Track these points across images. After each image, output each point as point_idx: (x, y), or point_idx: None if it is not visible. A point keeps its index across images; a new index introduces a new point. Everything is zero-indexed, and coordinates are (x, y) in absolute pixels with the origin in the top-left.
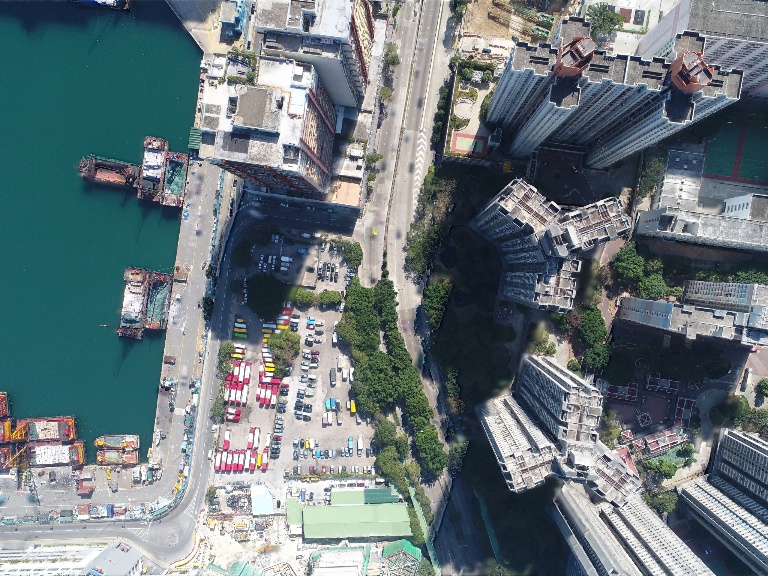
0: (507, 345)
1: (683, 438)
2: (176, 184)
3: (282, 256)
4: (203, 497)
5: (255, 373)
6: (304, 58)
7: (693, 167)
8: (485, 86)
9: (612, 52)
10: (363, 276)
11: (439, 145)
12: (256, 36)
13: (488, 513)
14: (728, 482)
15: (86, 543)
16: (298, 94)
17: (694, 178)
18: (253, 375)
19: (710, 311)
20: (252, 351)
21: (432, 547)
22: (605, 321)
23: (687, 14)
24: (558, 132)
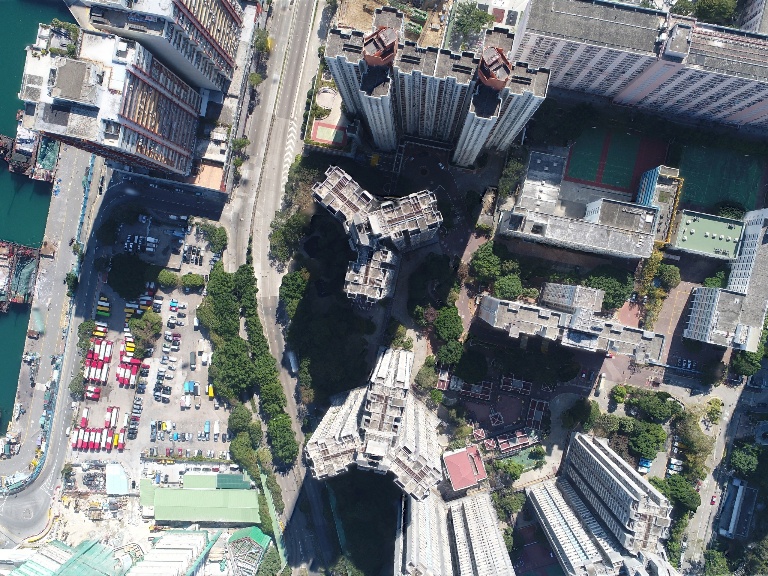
0: (367, 338)
1: (534, 440)
2: (48, 159)
3: (148, 237)
4: (60, 474)
5: (117, 352)
6: (133, 35)
7: (554, 169)
8: None
9: None
10: (228, 261)
11: None
12: None
13: (336, 504)
14: (572, 485)
15: None
16: (119, 70)
17: (554, 180)
18: (115, 354)
19: (536, 311)
20: (115, 330)
21: (280, 535)
22: (464, 319)
23: (528, 14)
24: (418, 127)
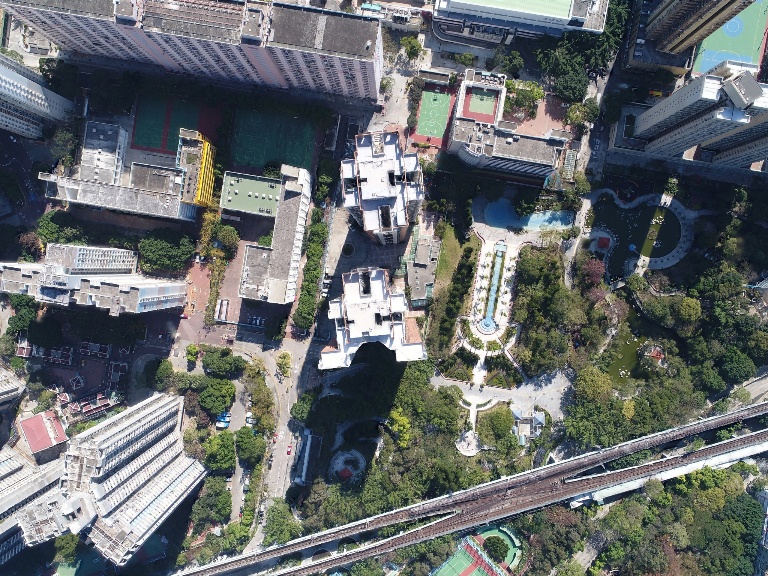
0: None
1: (116, 401)
2: None
3: None
4: None
5: None
6: None
7: (110, 138)
8: None
9: None
10: None
11: None
12: None
13: None
14: None
15: None
16: None
17: (111, 148)
18: None
19: (19, 270)
20: None
21: None
22: None
23: None
24: None
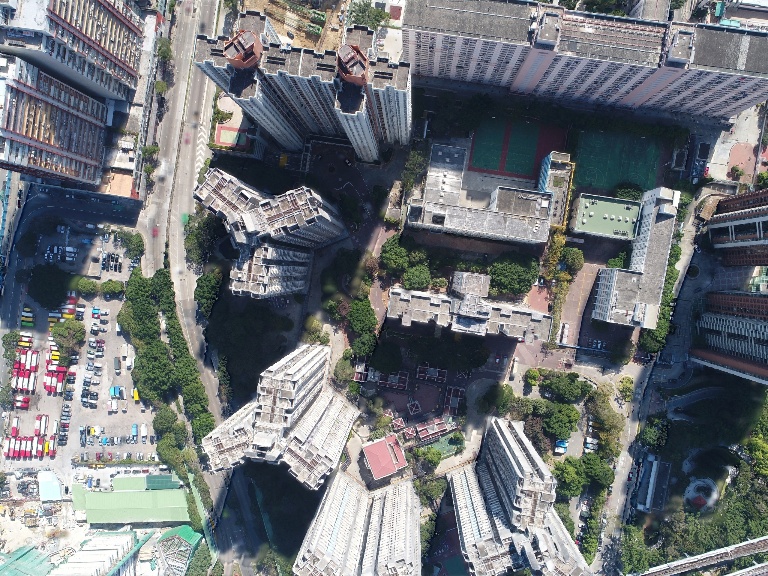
0: (285, 334)
1: (452, 426)
2: None
3: (67, 246)
4: None
5: (43, 361)
6: (15, 50)
7: (455, 161)
8: None
9: (383, 48)
10: (146, 266)
11: None
12: None
13: (262, 499)
14: (489, 469)
15: None
16: None
17: (456, 171)
18: (41, 363)
19: (427, 299)
20: (40, 340)
21: (209, 532)
22: (379, 311)
23: None
24: None
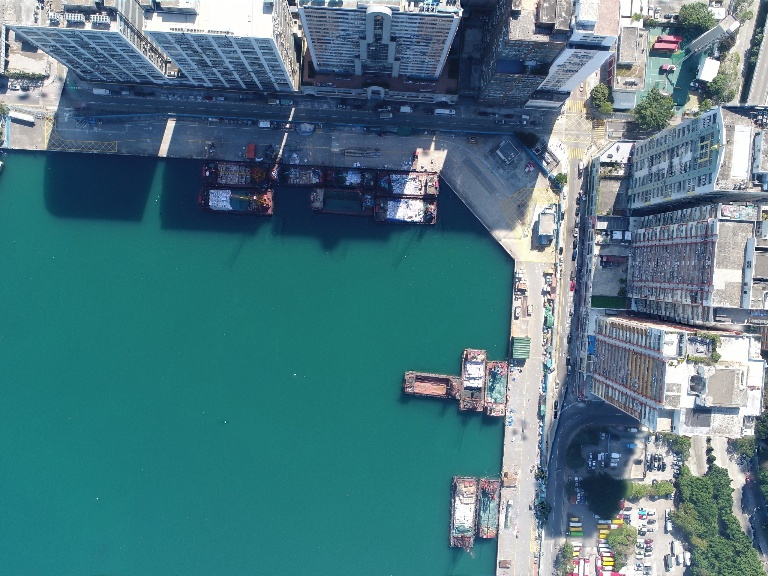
0: None
1: None
2: (498, 392)
3: (612, 453)
4: None
5: (591, 567)
6: None
7: None
8: None
9: None
10: (689, 463)
11: None
12: (567, 241)
13: None
14: None
15: None
16: (756, 367)
17: None
18: (589, 569)
19: None
20: (587, 547)
21: None
22: None
23: None
24: None
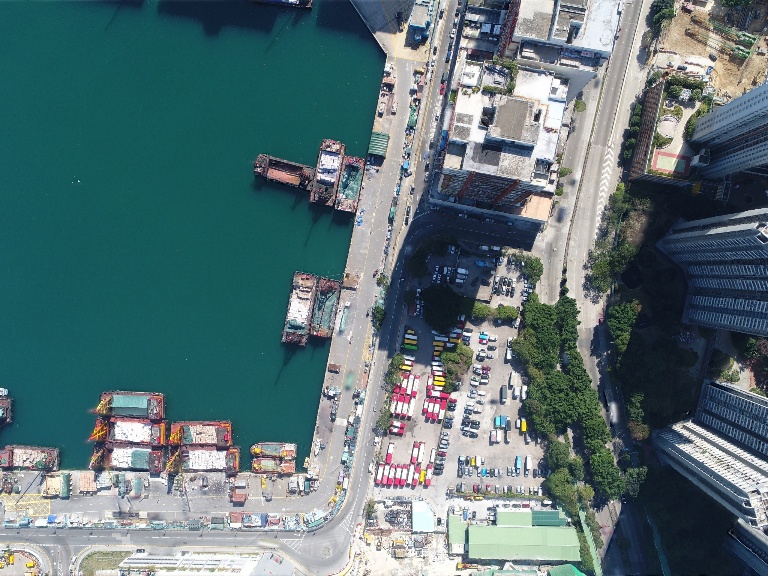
0: None
1: None
2: (351, 189)
3: (458, 268)
4: (360, 511)
5: (422, 386)
6: (556, 70)
7: None
8: (691, 105)
9: None
10: (540, 292)
11: (627, 162)
12: (443, 42)
13: (662, 542)
14: None
15: (236, 552)
16: (556, 107)
17: None
18: (420, 388)
19: None
20: (421, 363)
21: (601, 574)
22: None
23: None
24: None
